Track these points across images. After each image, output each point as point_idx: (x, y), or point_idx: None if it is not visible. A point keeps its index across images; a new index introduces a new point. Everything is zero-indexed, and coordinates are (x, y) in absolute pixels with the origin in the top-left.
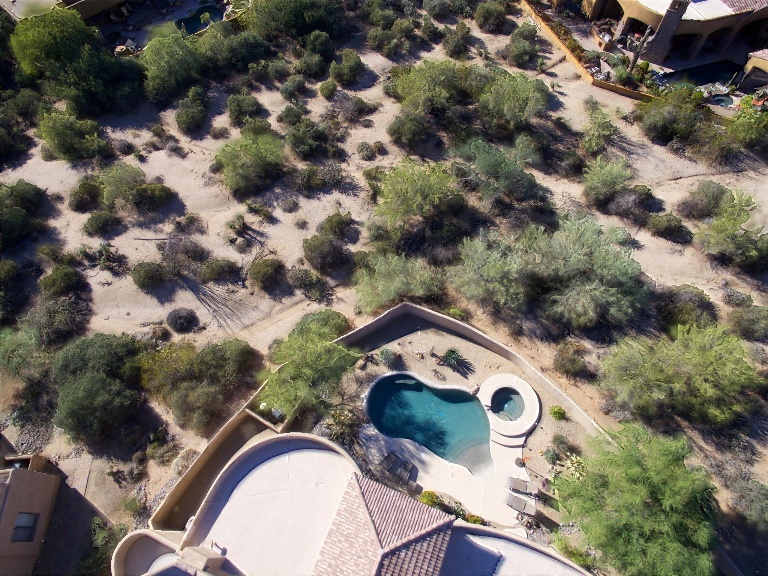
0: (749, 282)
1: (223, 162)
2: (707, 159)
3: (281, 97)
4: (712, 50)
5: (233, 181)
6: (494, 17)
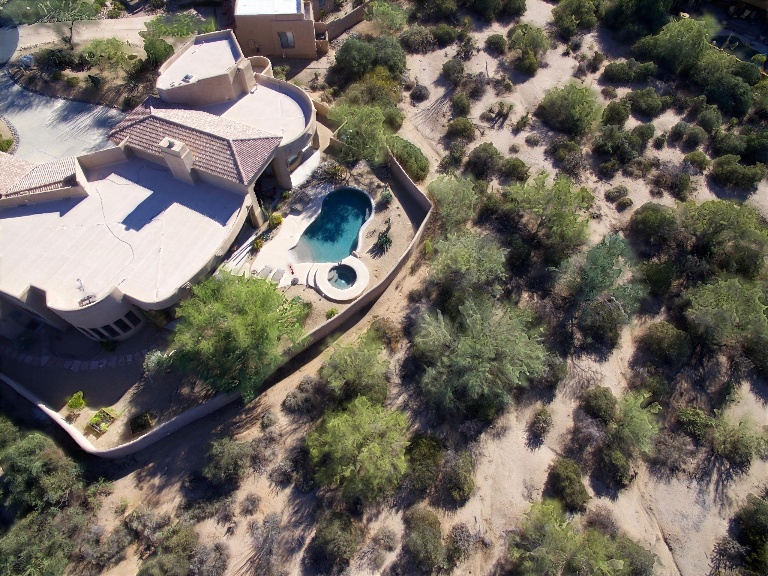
0: None
1: None
2: None
3: None
4: None
5: (546, 96)
6: None
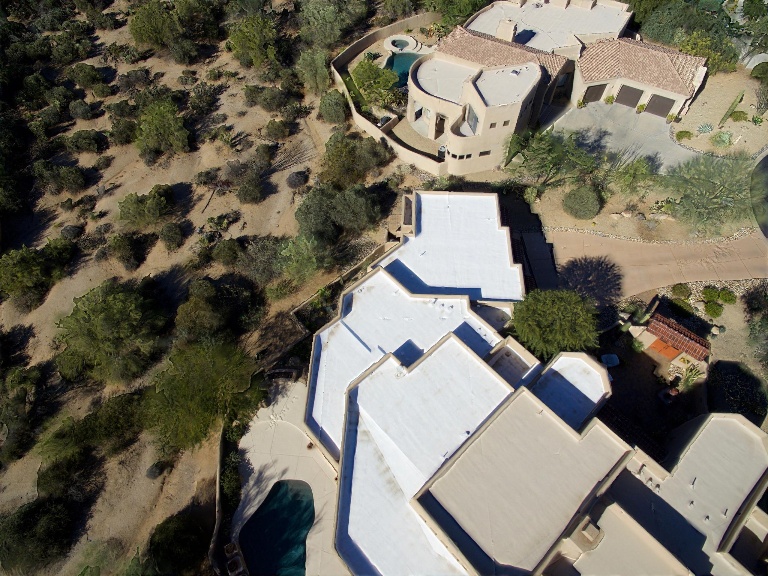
0: None
1: (153, 147)
2: None
3: (86, 122)
4: None
5: (183, 135)
6: None
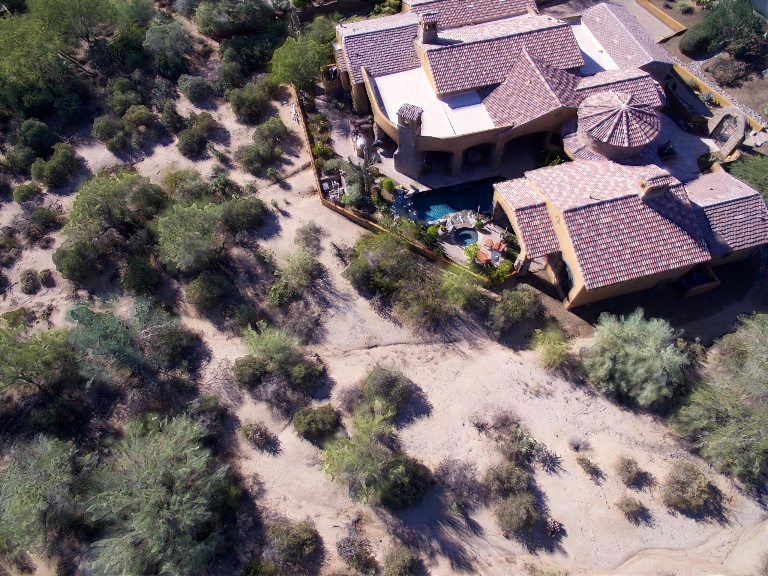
0: (388, 520)
1: None
2: (414, 323)
3: None
4: (483, 163)
5: None
6: (245, 106)
